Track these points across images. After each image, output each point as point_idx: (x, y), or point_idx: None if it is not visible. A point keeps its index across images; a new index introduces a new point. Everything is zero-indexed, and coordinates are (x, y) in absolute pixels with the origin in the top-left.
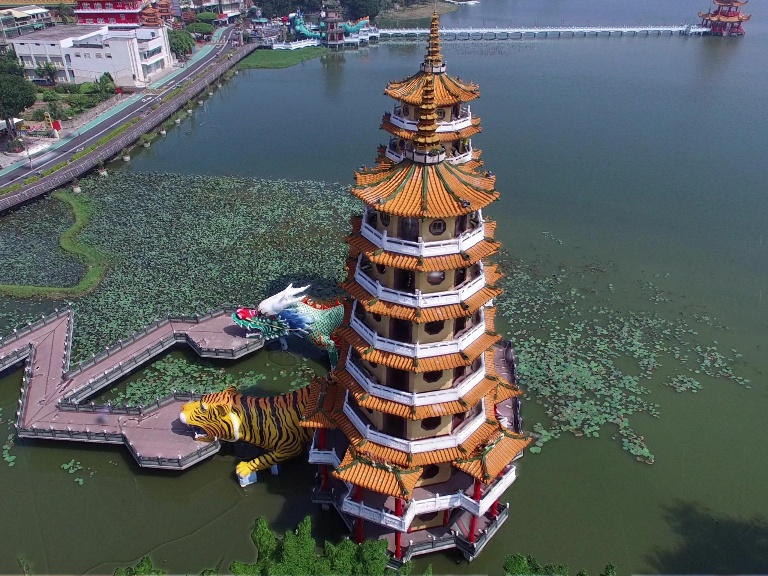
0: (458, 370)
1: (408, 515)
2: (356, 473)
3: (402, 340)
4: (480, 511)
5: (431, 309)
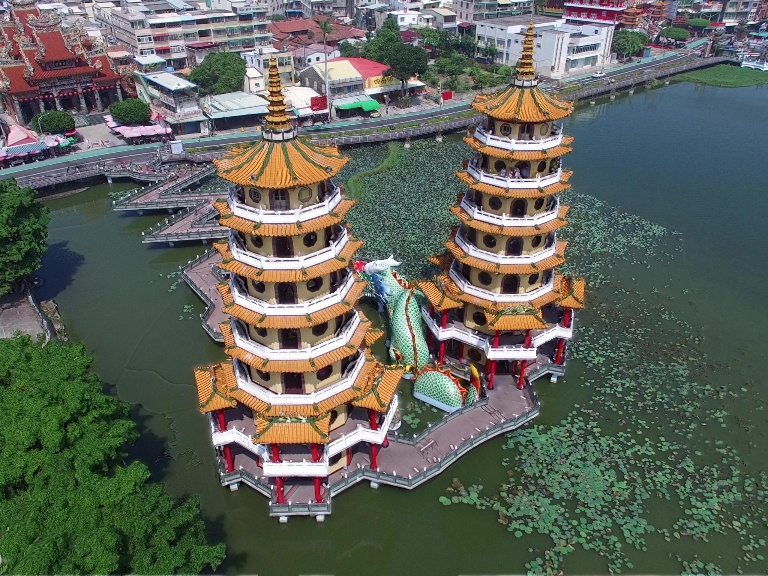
0: (295, 342)
1: (224, 435)
2: (203, 377)
3: None
4: (266, 470)
5: (242, 264)
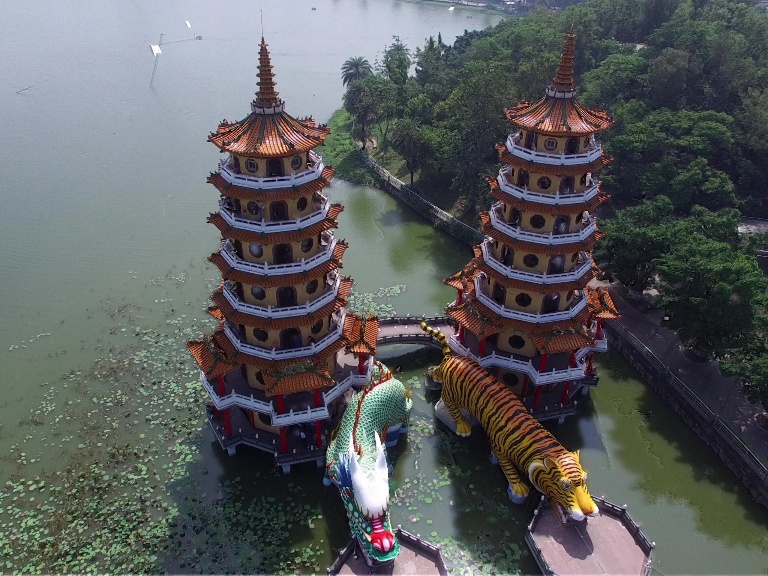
0: None
1: None
2: None
3: None
4: None
5: None
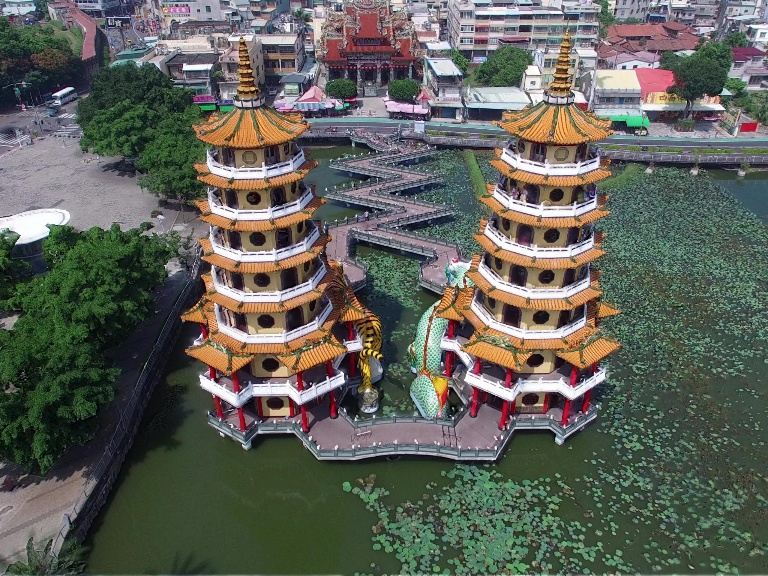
0: None
1: None
2: None
3: None
4: None
5: None
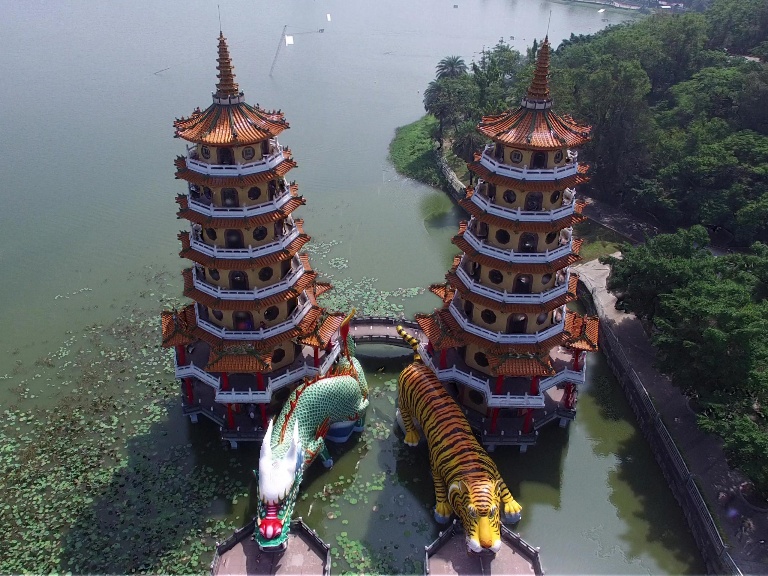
0: None
1: None
2: None
3: (558, 241)
4: None
5: None
